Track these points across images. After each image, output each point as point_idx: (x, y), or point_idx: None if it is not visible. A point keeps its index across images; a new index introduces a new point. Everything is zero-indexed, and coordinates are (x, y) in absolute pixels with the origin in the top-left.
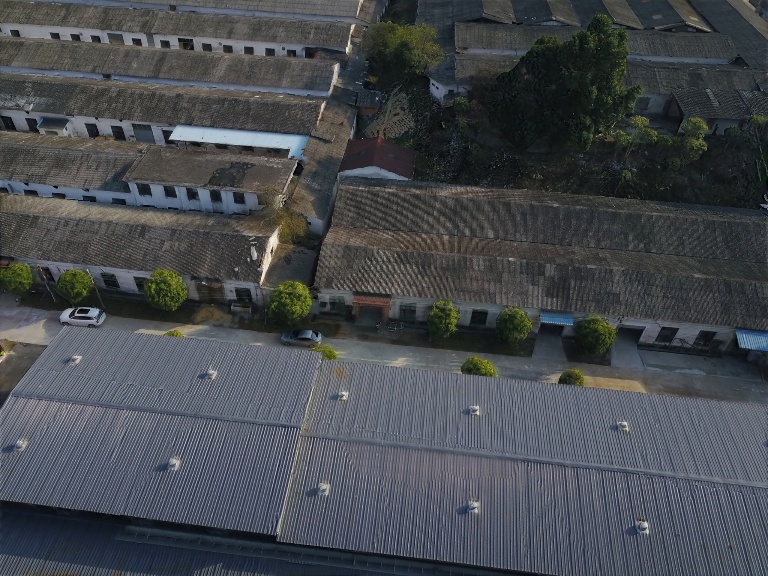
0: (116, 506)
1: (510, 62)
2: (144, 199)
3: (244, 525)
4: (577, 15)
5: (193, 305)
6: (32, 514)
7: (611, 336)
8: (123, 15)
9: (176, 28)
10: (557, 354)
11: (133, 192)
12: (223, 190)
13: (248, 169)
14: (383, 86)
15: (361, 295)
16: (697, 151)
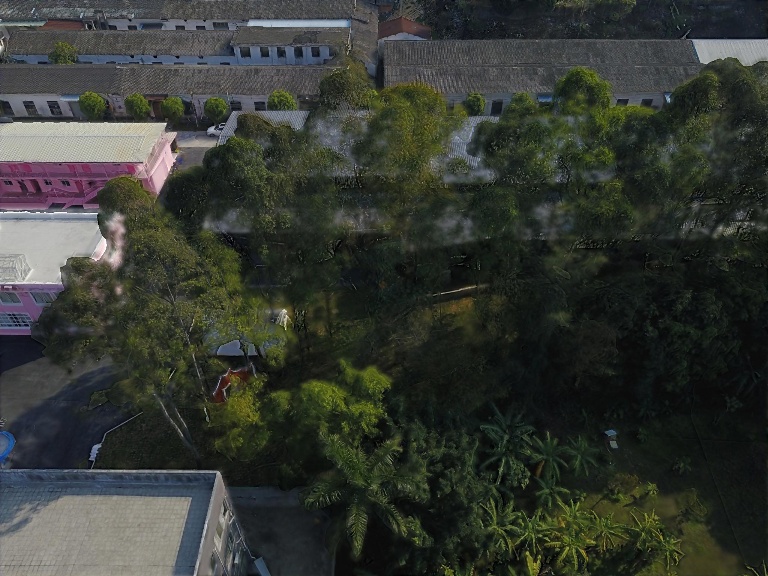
0: None
1: None
2: (244, 61)
3: None
4: None
5: None
6: None
7: None
8: None
9: None
10: None
11: (237, 55)
12: (304, 46)
13: (318, 34)
14: None
15: None
16: (629, 5)
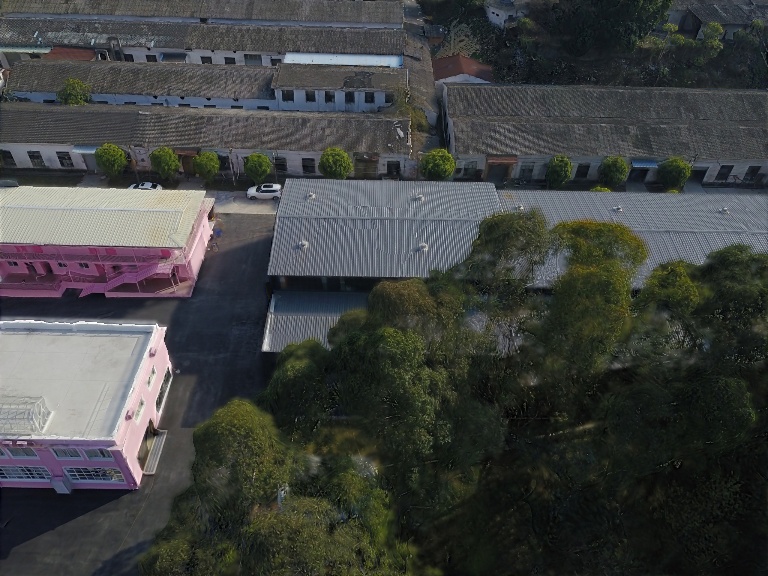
0: (395, 272)
1: None
2: (286, 105)
3: None
4: None
5: None
6: (321, 293)
7: (689, 171)
8: None
9: None
10: None
11: (278, 99)
12: (357, 91)
13: (371, 76)
14: (440, 22)
15: (494, 157)
16: (716, 49)
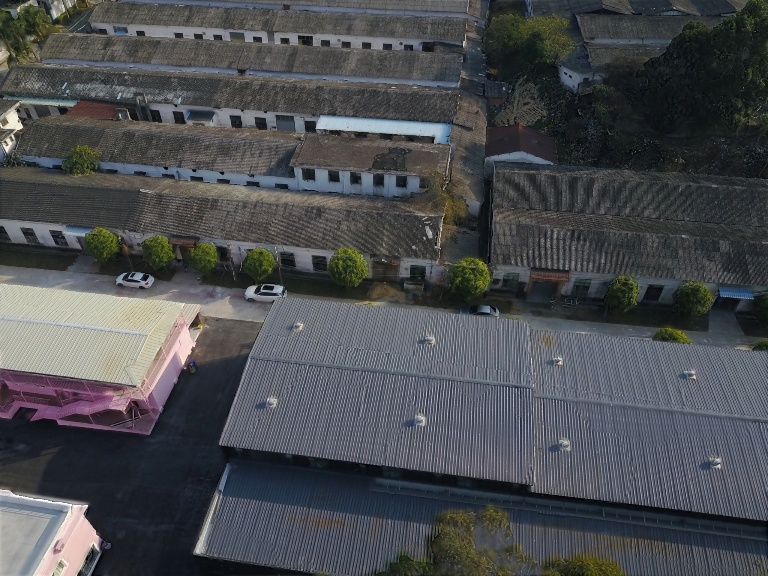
0: (376, 457)
1: (644, 50)
2: (307, 184)
3: (502, 476)
4: (694, 5)
5: (366, 283)
6: (286, 467)
7: None
8: (244, 15)
9: (296, 26)
10: (734, 329)
11: (297, 177)
12: (387, 174)
13: (406, 154)
14: (505, 77)
15: (539, 271)
16: None
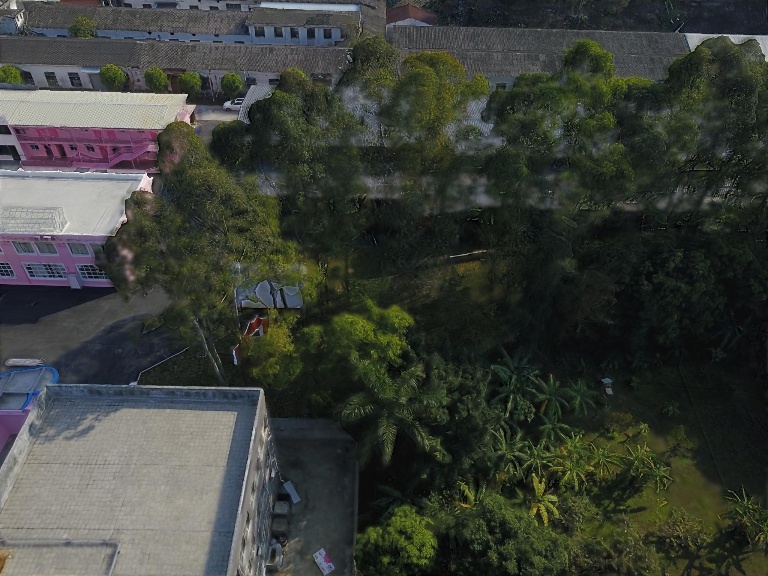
0: None
1: None
2: (258, 40)
3: None
4: None
5: None
6: None
7: None
8: None
9: None
10: None
11: (251, 35)
12: (317, 28)
13: (330, 16)
14: None
15: None
16: None
